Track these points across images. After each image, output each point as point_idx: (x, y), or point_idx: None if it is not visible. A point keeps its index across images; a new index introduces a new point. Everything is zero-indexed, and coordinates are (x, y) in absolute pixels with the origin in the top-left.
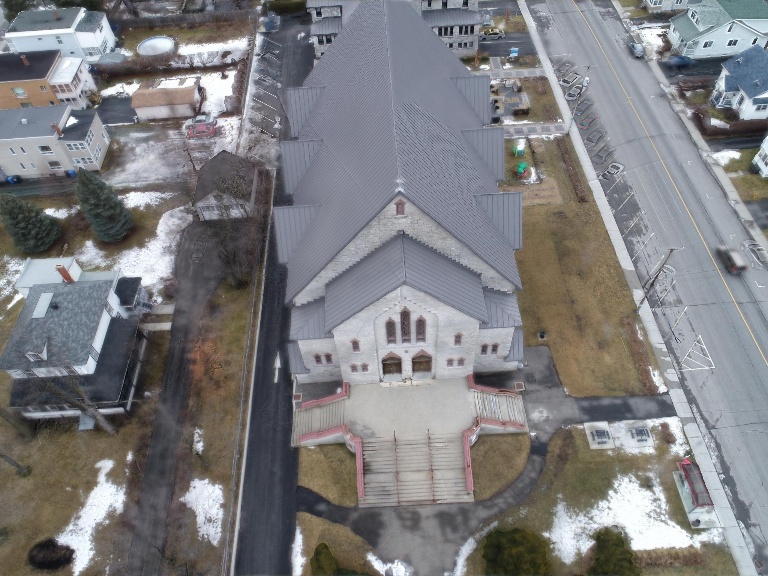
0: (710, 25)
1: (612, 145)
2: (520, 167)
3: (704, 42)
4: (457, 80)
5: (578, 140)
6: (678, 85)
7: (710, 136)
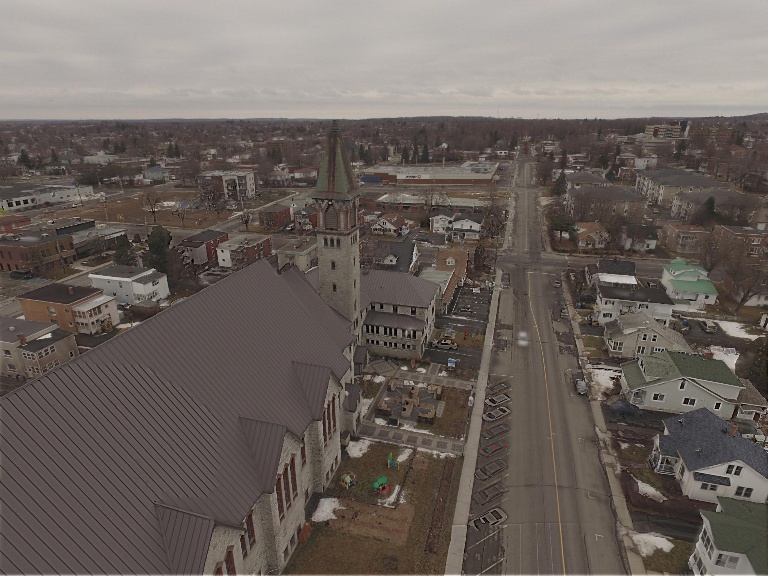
0: (657, 377)
1: (506, 484)
2: (377, 481)
3: (653, 394)
4: (298, 365)
5: (470, 467)
6: (616, 433)
7: (636, 507)
